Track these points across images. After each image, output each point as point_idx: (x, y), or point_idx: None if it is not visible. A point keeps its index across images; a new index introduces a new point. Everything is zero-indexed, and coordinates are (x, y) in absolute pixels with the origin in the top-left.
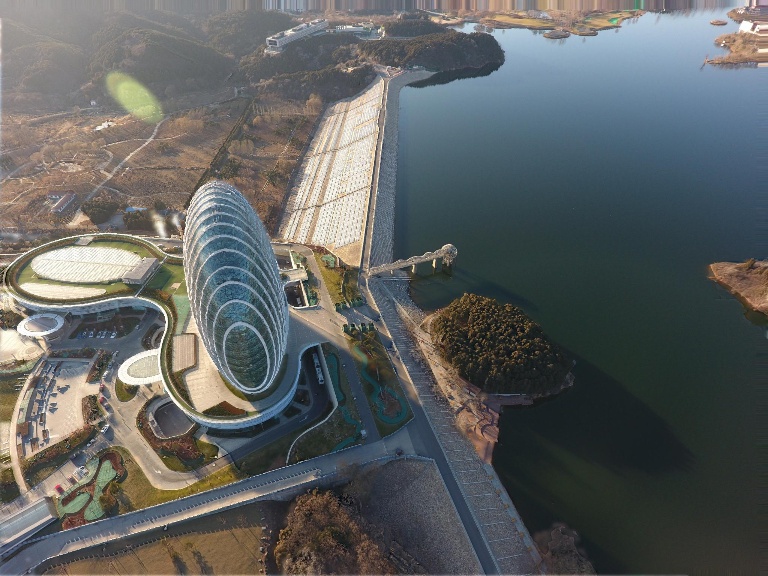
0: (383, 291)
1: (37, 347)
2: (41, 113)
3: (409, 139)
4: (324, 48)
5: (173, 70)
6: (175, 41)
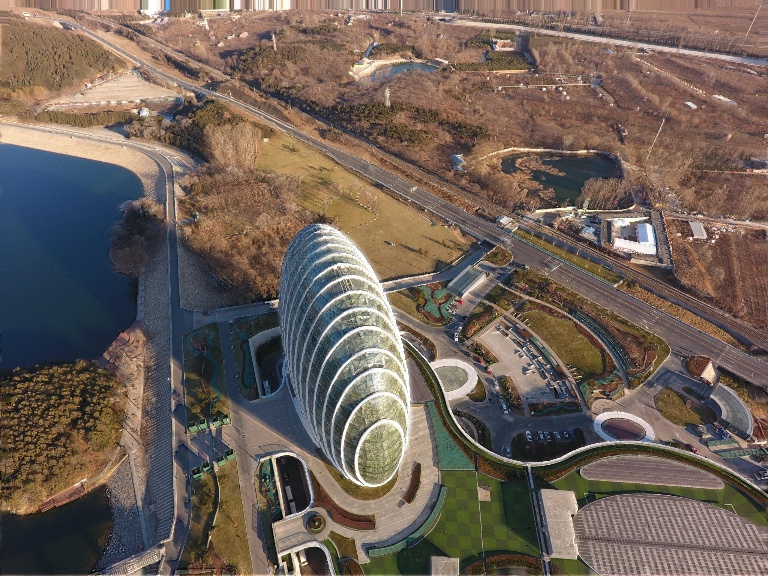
0: (152, 525)
1: None
2: None
3: None
4: None
5: None
6: None
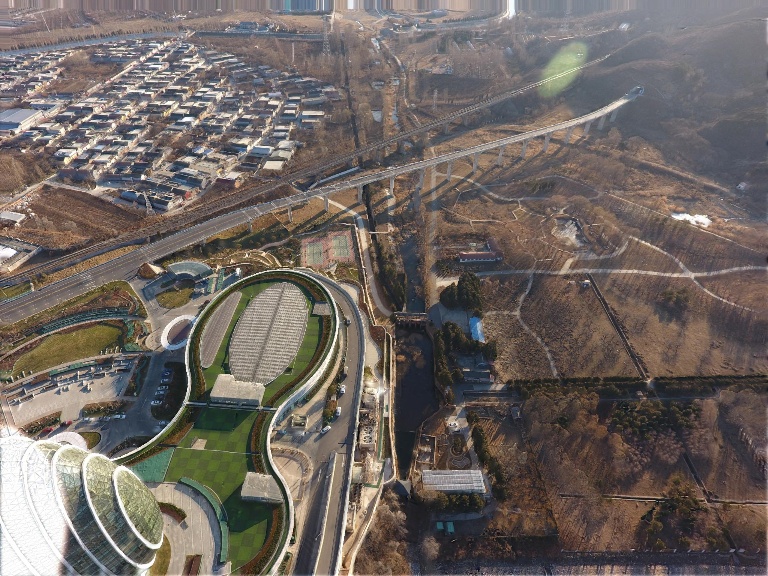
0: None
1: None
2: (672, 162)
3: None
4: None
5: None
6: None
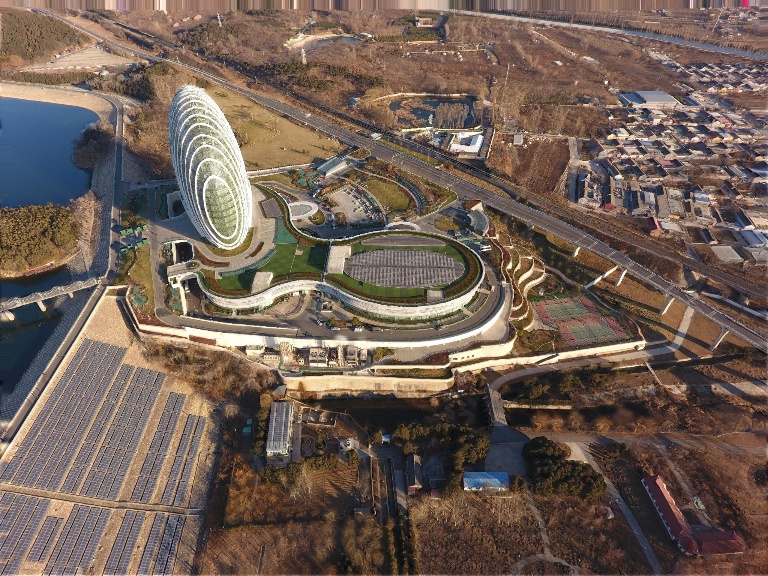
0: (95, 276)
1: None
2: None
3: None
4: None
5: None
6: None
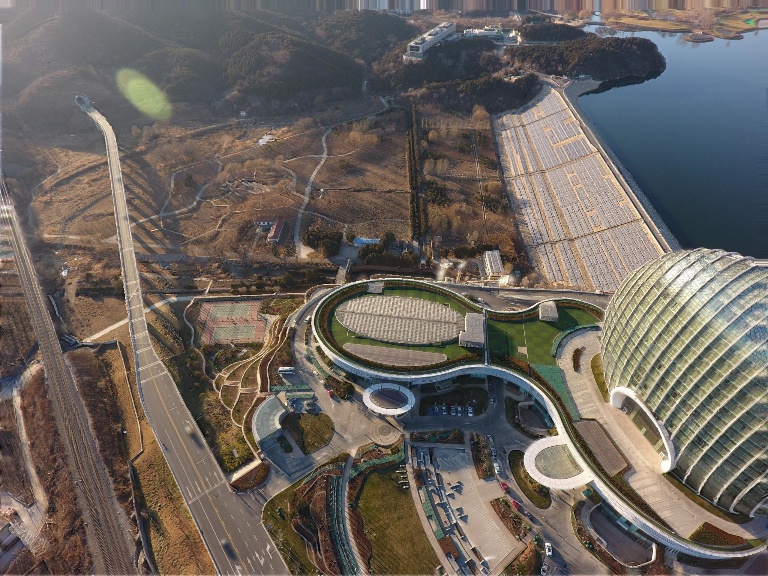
0: None
1: (389, 426)
2: (195, 125)
3: (632, 161)
4: (466, 54)
5: (319, 78)
6: (313, 47)
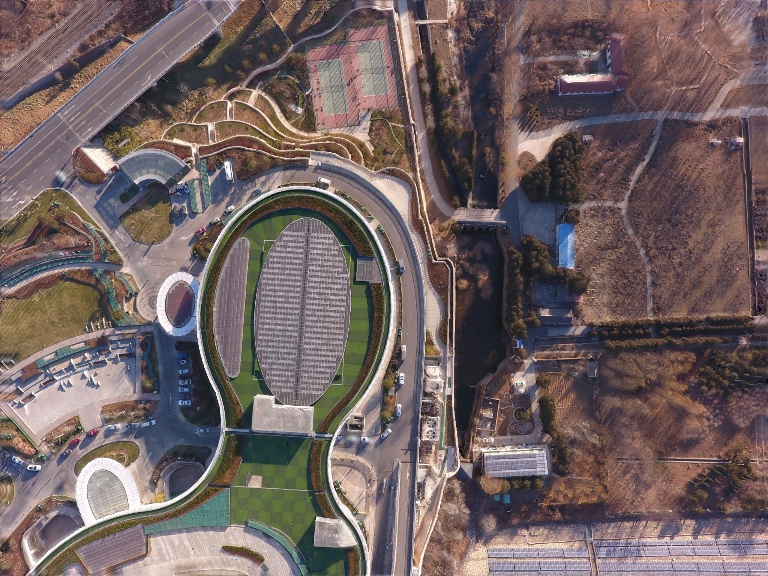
0: None
1: None
2: None
3: None
4: None
5: None
6: None
